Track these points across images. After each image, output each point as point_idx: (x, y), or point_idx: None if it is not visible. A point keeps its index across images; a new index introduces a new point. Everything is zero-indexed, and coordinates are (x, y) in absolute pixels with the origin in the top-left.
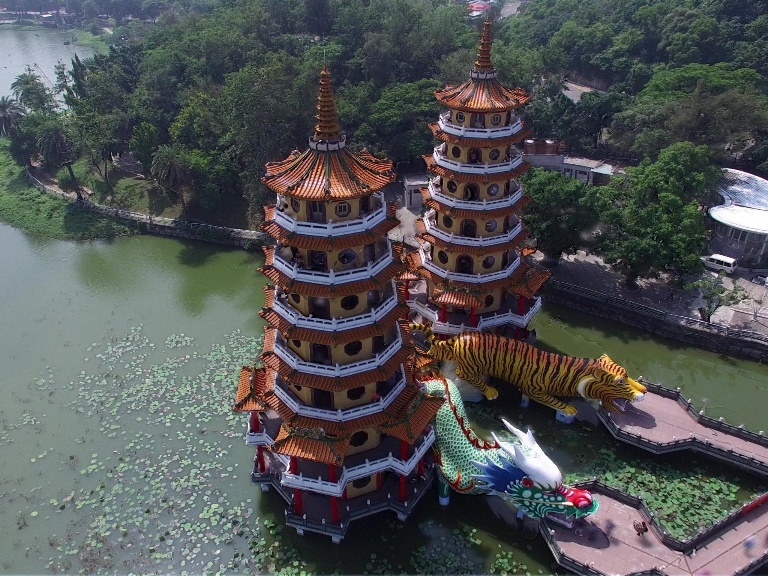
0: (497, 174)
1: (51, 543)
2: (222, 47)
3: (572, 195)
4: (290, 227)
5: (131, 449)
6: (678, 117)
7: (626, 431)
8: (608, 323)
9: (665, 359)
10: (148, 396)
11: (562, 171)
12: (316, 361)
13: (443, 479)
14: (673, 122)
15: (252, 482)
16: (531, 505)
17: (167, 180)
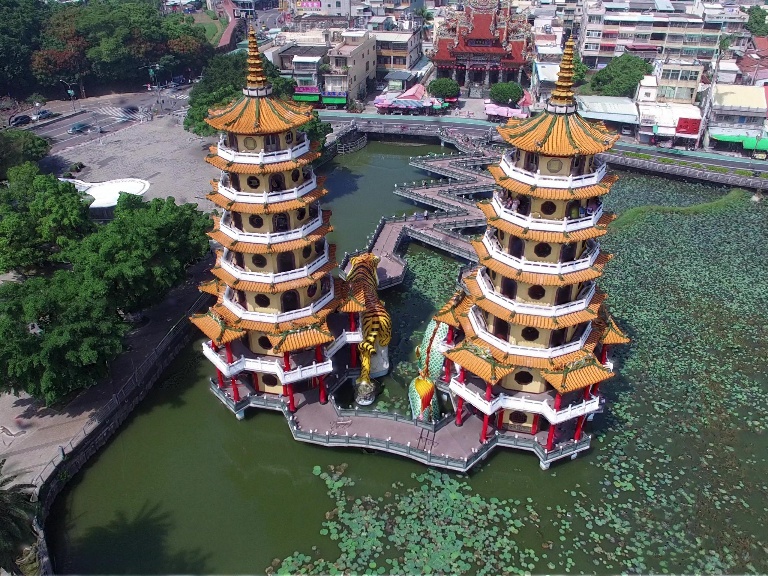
0: None
1: None
2: None
3: None
4: None
5: None
6: None
7: None
8: None
9: None
10: None
11: None
12: None
13: None
14: None
15: None
16: None
17: None
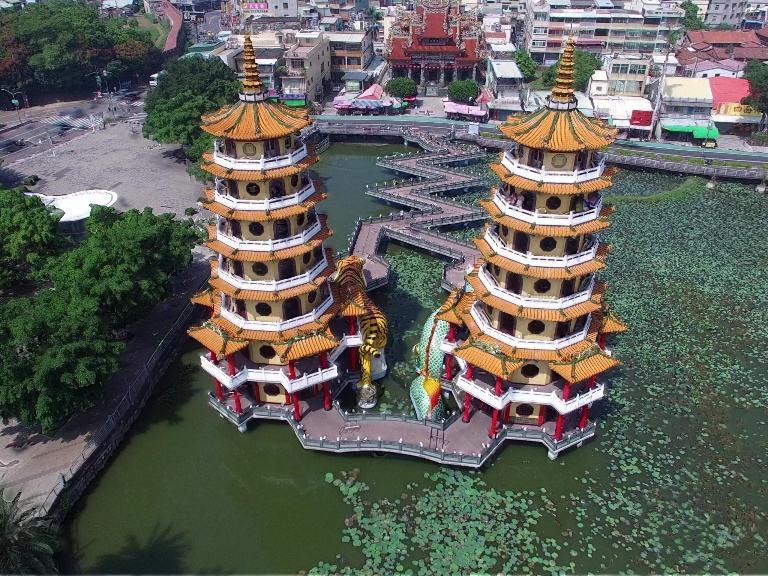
0: None
1: None
2: None
3: None
4: None
5: None
6: None
7: None
8: None
9: None
10: None
11: None
12: None
13: None
14: None
15: None
16: None
17: None
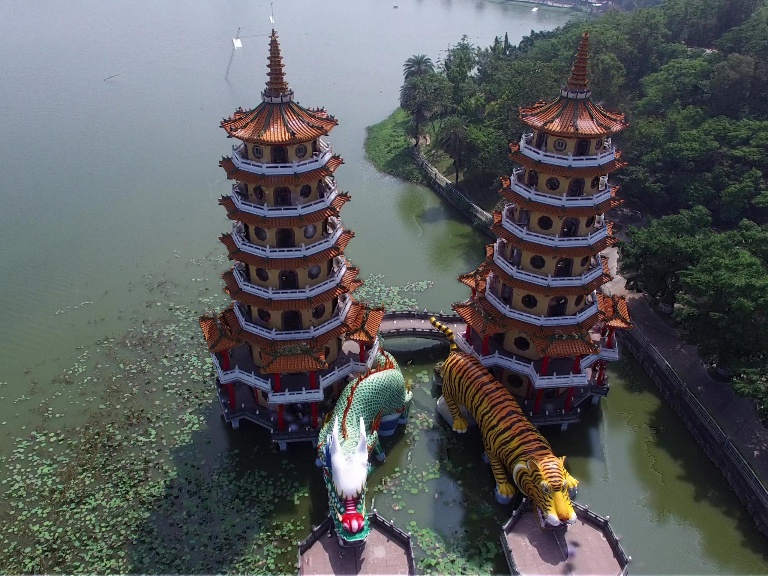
0: (542, 204)
1: (144, 321)
2: (595, 44)
3: (740, 292)
4: None
5: None
6: None
7: (506, 536)
8: (711, 471)
9: None
10: None
11: None
12: (247, 273)
13: None
14: None
15: None
16: None
17: (443, 144)
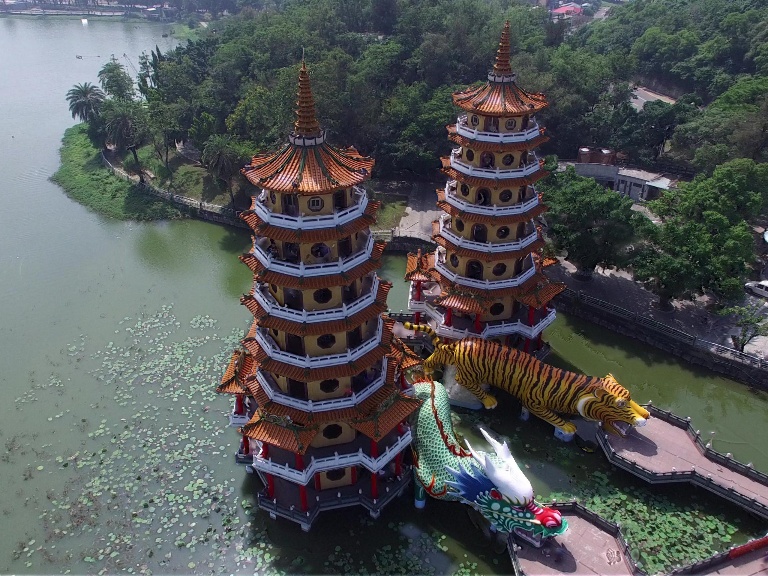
0: (509, 180)
1: (48, 496)
2: (287, 43)
3: (605, 207)
4: (265, 218)
5: (137, 419)
6: (741, 132)
7: (621, 456)
8: (634, 343)
9: (695, 387)
10: (163, 371)
11: (616, 182)
12: (291, 351)
13: (418, 482)
14: (735, 137)
15: (236, 462)
16: (500, 518)
17: (215, 168)
